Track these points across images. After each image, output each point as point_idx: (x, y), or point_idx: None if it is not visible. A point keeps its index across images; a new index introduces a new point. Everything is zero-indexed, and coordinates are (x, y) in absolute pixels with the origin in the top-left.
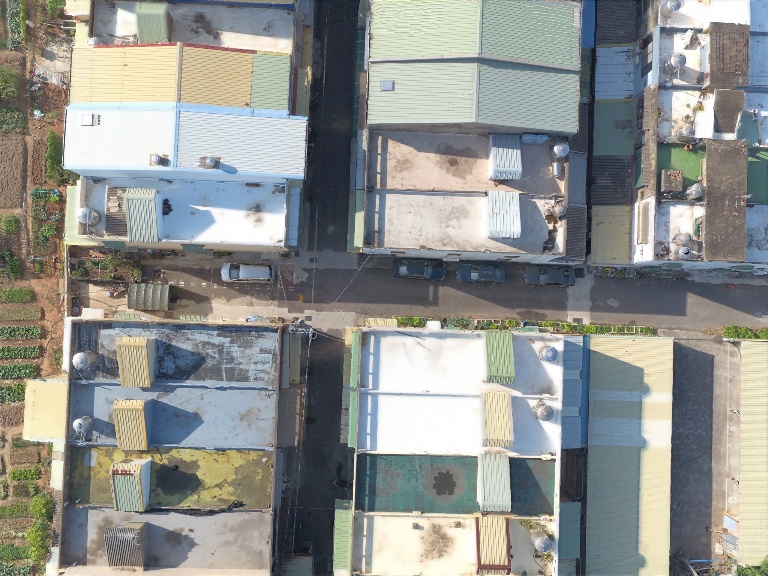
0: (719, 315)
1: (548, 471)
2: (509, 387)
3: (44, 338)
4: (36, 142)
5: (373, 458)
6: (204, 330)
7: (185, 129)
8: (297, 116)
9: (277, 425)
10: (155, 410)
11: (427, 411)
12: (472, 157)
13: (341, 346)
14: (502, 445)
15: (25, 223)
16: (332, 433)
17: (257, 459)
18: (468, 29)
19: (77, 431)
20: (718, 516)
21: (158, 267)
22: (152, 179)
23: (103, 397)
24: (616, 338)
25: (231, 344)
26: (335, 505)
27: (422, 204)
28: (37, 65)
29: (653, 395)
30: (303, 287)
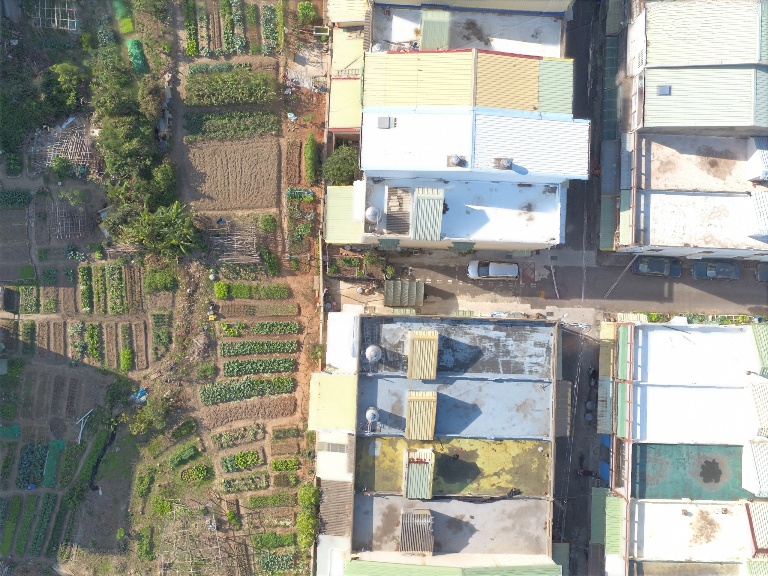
0: None
1: None
2: None
3: (301, 333)
4: (290, 144)
5: (643, 447)
6: (481, 324)
7: (482, 132)
8: (580, 119)
9: None
10: None
11: (693, 402)
12: (731, 159)
13: (581, 341)
14: None
15: (280, 222)
16: None
17: (533, 448)
18: (747, 37)
19: (371, 421)
20: None
21: (405, 265)
22: (431, 179)
23: (386, 389)
24: None
25: (507, 338)
26: (592, 493)
27: (685, 204)
28: (289, 70)
29: None
30: (545, 284)
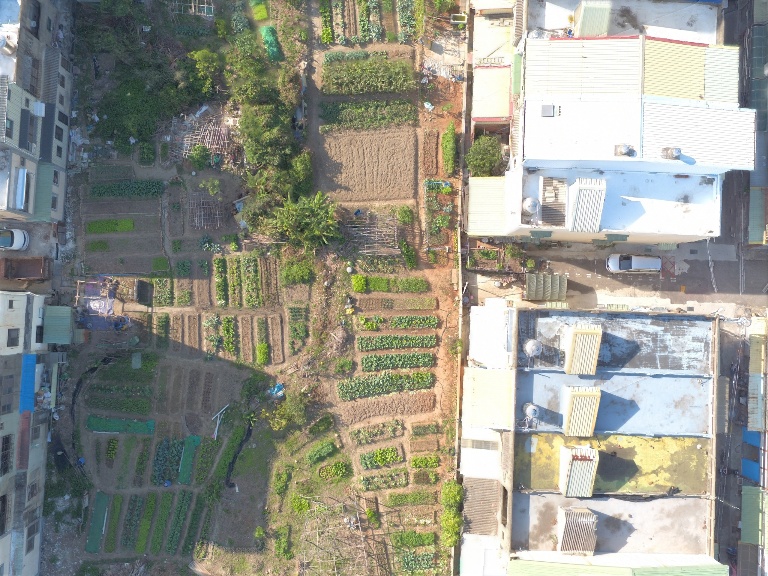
0: None
1: None
2: None
3: (439, 327)
4: (427, 134)
5: None
6: (638, 319)
7: (650, 120)
8: (746, 108)
9: None
10: None
11: None
12: None
13: (722, 336)
14: None
15: (417, 214)
16: None
17: (692, 446)
18: None
19: (532, 417)
20: None
21: (543, 258)
22: (587, 170)
23: (542, 384)
24: None
25: (664, 332)
26: (743, 492)
27: None
28: (426, 58)
29: None
30: (685, 278)
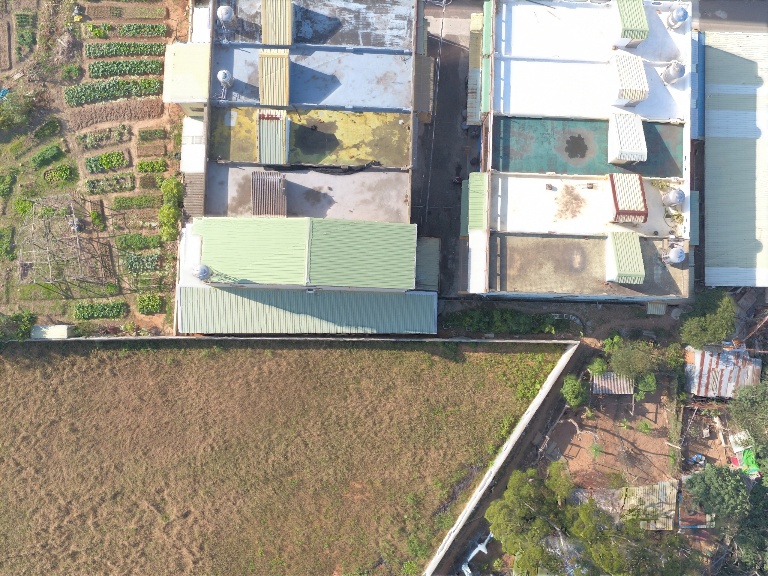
0: None
1: (676, 136)
2: (637, 55)
3: (169, 36)
4: None
5: (507, 121)
6: None
7: None
8: None
9: None
10: (294, 72)
11: (558, 77)
12: None
13: (459, 51)
14: (637, 97)
15: None
16: (451, 135)
17: (394, 121)
18: None
19: (222, 80)
20: None
21: None
22: None
23: (242, 59)
24: (730, 35)
25: (367, 10)
26: (462, 186)
27: None
28: None
29: (767, 88)
30: None
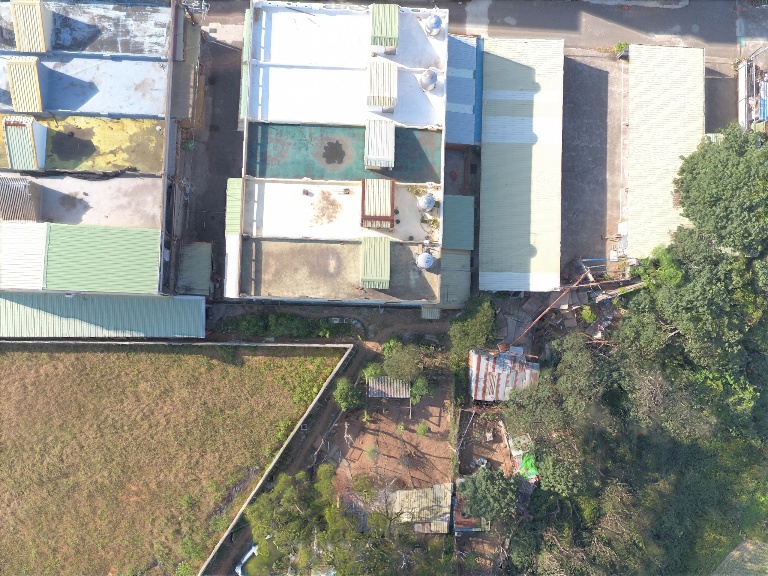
0: (613, 34)
1: (435, 142)
2: (397, 62)
3: None
4: None
5: (264, 128)
6: (100, 4)
7: None
8: None
9: (171, 95)
10: (51, 79)
11: (317, 84)
12: None
13: None
14: (386, 104)
15: None
16: (236, 140)
17: (151, 127)
18: None
19: None
20: (613, 225)
21: None
22: None
23: (1, 66)
24: (509, 41)
25: (126, 18)
26: None
27: None
28: None
29: (544, 94)
30: (208, 1)
